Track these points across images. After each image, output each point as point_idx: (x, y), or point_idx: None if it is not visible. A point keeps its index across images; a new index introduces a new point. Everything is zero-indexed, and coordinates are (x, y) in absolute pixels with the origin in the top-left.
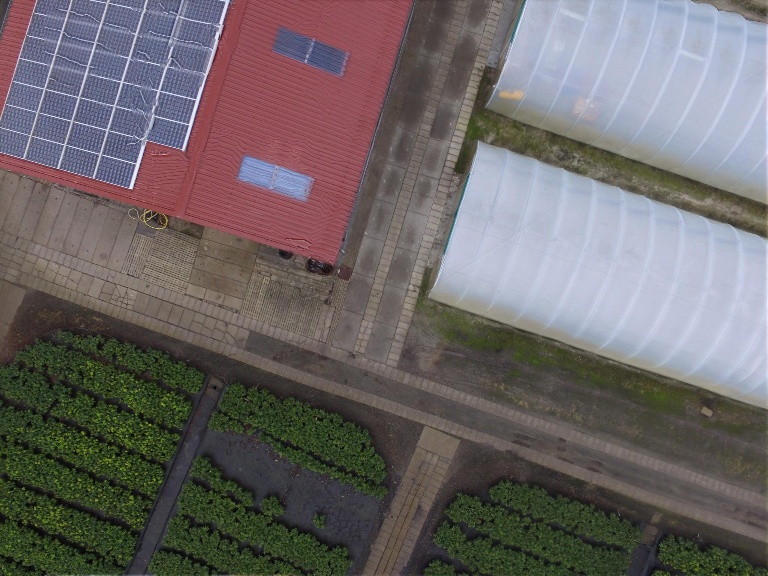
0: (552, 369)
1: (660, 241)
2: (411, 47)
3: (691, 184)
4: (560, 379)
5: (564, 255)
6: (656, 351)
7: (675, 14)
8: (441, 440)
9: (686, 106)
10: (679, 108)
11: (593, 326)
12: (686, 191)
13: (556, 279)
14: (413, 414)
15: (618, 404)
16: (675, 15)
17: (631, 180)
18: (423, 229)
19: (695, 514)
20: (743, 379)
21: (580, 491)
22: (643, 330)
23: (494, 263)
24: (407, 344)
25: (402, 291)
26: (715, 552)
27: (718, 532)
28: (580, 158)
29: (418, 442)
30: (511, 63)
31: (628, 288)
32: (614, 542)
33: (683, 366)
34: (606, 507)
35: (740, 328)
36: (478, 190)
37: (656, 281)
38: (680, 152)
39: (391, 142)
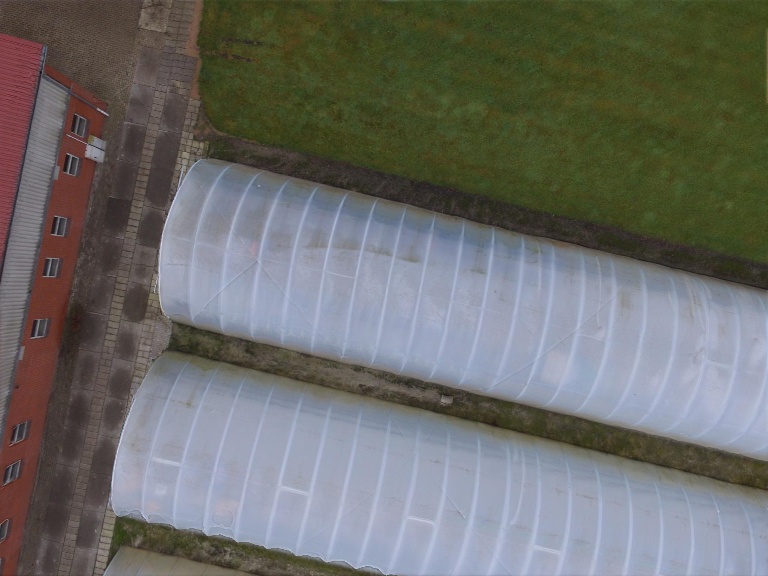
0: None
1: None
2: (48, 457)
3: (347, 567)
4: None
5: None
6: None
7: (276, 446)
8: None
9: (297, 535)
10: (292, 536)
11: None
12: (343, 573)
13: None
14: None
15: None
16: (276, 448)
17: (286, 568)
18: None
19: None
20: None
21: None
22: None
23: None
24: None
25: None
26: None
27: None
28: (232, 551)
29: None
30: (118, 505)
31: None
32: None
33: None
34: None
35: None
36: None
37: None
38: None
39: (37, 554)
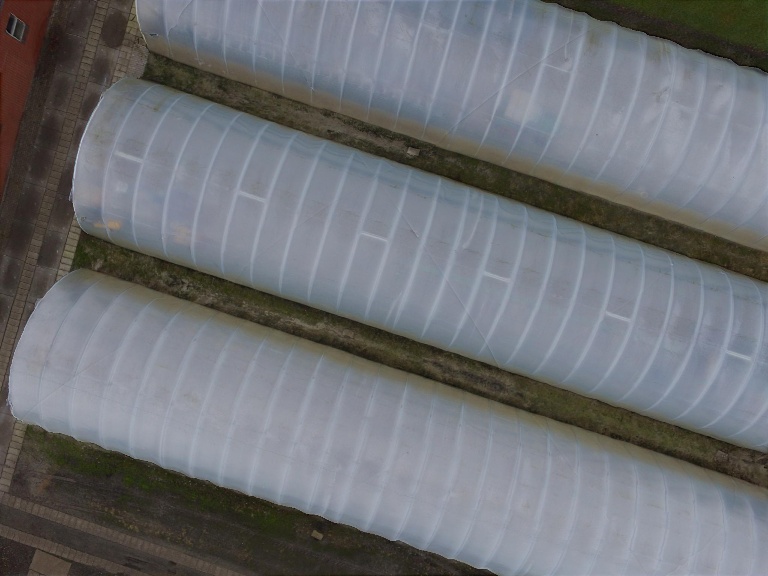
0: (162, 493)
1: (221, 383)
2: (16, 174)
3: (302, 309)
4: (170, 503)
5: (120, 399)
6: (238, 485)
7: (238, 153)
8: (53, 563)
9: (252, 245)
10: (247, 247)
11: (170, 462)
12: (297, 316)
13: (117, 421)
14: (25, 538)
15: (228, 528)
16: (238, 155)
17: (241, 305)
18: None
19: None
20: (324, 513)
21: None
22: (213, 468)
23: (57, 405)
24: (18, 469)
25: (12, 418)
26: None
27: None
28: (189, 284)
29: (30, 565)
30: (79, 203)
31: (186, 431)
32: None
33: (268, 499)
34: None
35: (300, 469)
36: (35, 335)
37: (213, 424)
38: (274, 282)
39: None
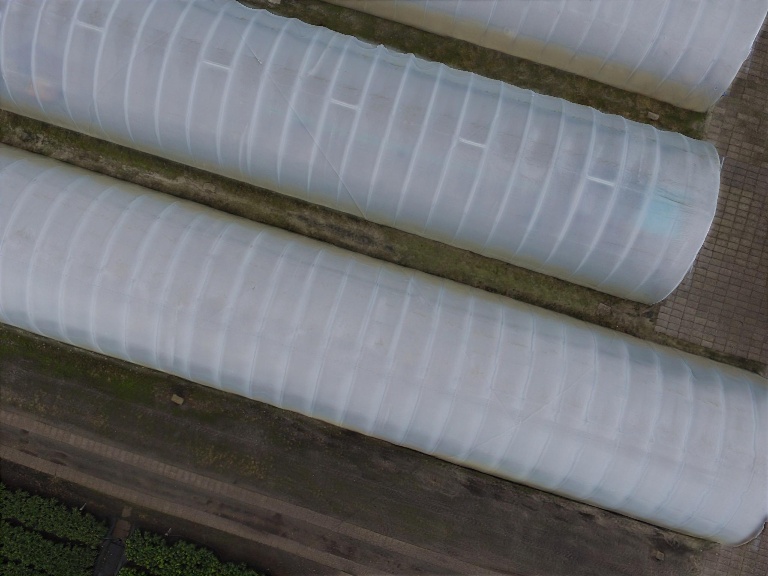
0: (15, 357)
1: (58, 219)
2: None
3: (160, 162)
4: (22, 368)
5: None
6: (83, 335)
7: None
8: None
9: (93, 79)
10: (88, 81)
11: (10, 310)
12: (156, 169)
13: None
14: None
15: (83, 393)
16: None
17: (98, 160)
18: None
19: (164, 507)
20: (173, 363)
21: (46, 485)
22: (52, 313)
23: None
24: None
25: None
26: (180, 547)
27: (190, 526)
28: (44, 138)
29: None
30: None
31: (20, 269)
32: (77, 538)
33: (116, 351)
34: (74, 501)
35: (139, 309)
36: None
37: (47, 261)
38: (125, 128)
39: None
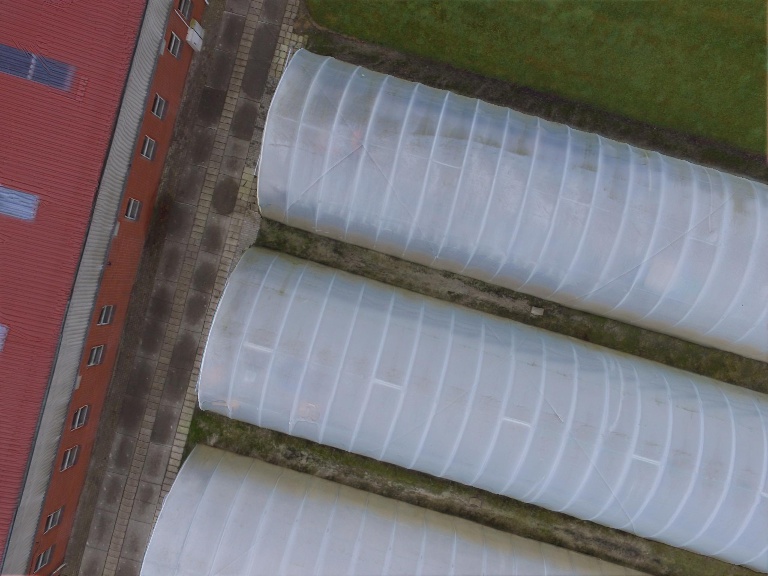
0: None
1: None
2: (127, 348)
3: (426, 478)
4: None
5: None
6: None
7: (371, 338)
8: None
9: (387, 432)
10: (381, 433)
11: None
12: (422, 485)
13: None
14: None
15: None
16: (371, 339)
17: (363, 476)
18: (146, 537)
19: None
20: None
21: None
22: None
23: None
24: None
25: None
26: None
27: None
28: (309, 456)
29: None
30: (204, 392)
31: None
32: None
33: None
34: None
35: None
36: (165, 536)
37: None
38: (402, 459)
39: (110, 448)
